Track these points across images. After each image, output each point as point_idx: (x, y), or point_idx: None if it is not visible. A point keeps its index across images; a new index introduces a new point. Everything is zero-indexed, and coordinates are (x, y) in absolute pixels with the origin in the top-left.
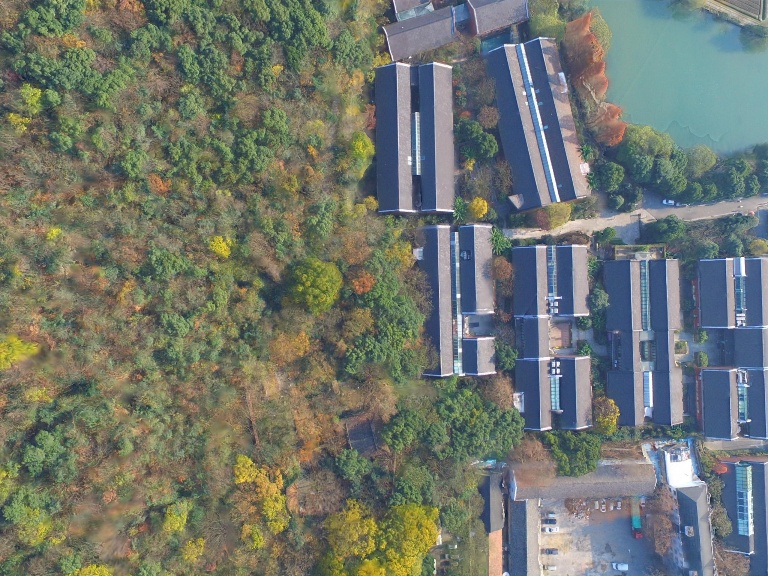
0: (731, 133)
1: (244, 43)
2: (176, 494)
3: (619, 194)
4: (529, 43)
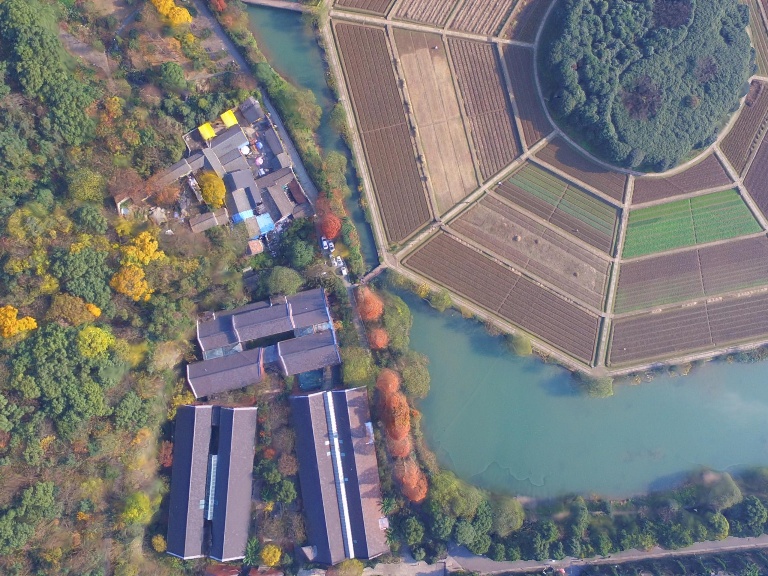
0: (552, 479)
1: (11, 419)
2: None
3: (421, 546)
4: (336, 392)
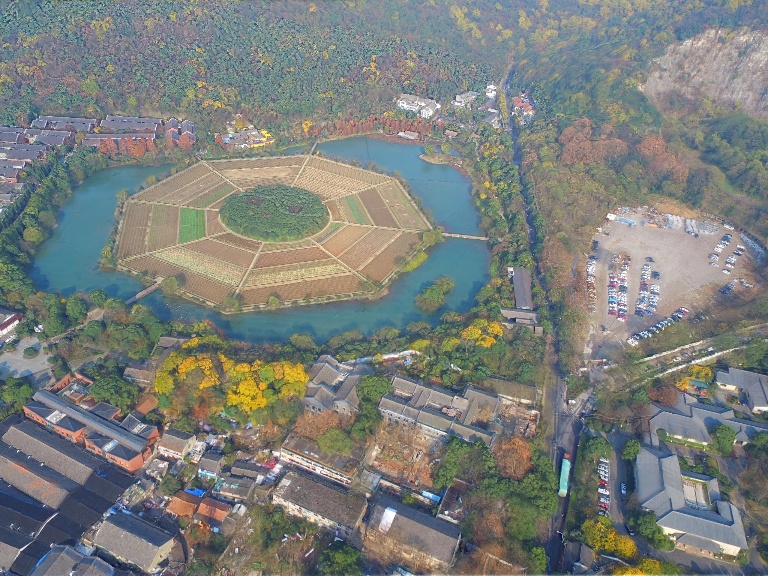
0: None
1: None
2: (45, 58)
3: None
4: None
